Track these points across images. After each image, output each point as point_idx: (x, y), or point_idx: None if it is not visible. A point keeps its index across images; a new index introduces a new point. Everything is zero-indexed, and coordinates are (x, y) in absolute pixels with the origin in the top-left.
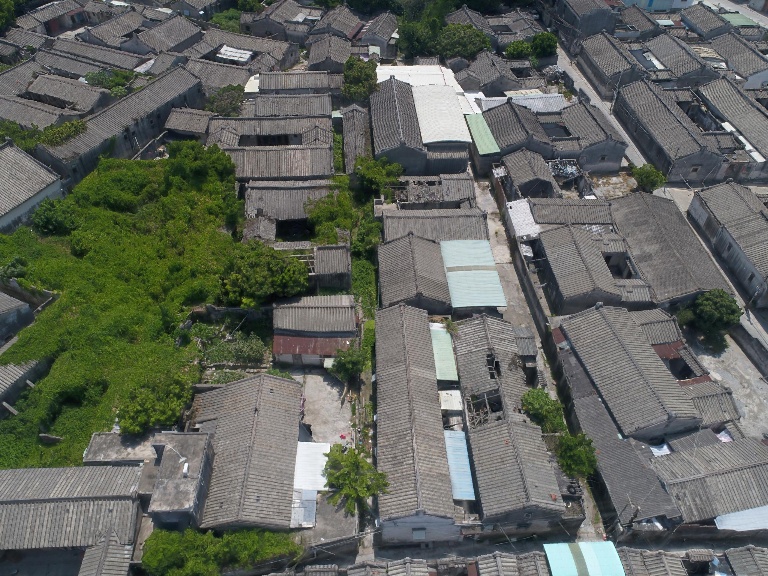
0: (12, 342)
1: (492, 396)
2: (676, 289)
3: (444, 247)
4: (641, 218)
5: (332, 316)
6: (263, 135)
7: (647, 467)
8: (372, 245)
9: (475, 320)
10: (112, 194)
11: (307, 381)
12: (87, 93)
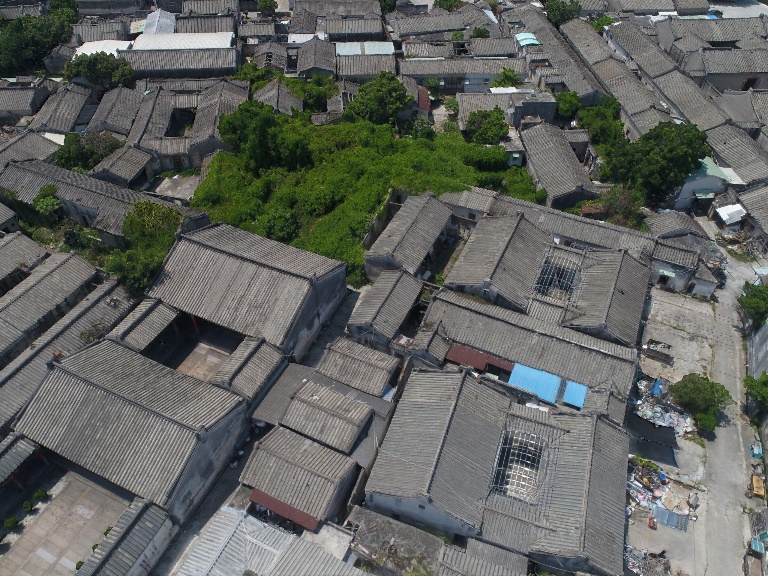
0: (447, 195)
1: (456, 46)
2: (375, 7)
3: (342, 54)
4: (317, 6)
5: (408, 83)
6: (168, 126)
7: (479, 27)
8: (332, 81)
9: (407, 46)
10: (256, 189)
11: (437, 114)
12: (7, 251)
